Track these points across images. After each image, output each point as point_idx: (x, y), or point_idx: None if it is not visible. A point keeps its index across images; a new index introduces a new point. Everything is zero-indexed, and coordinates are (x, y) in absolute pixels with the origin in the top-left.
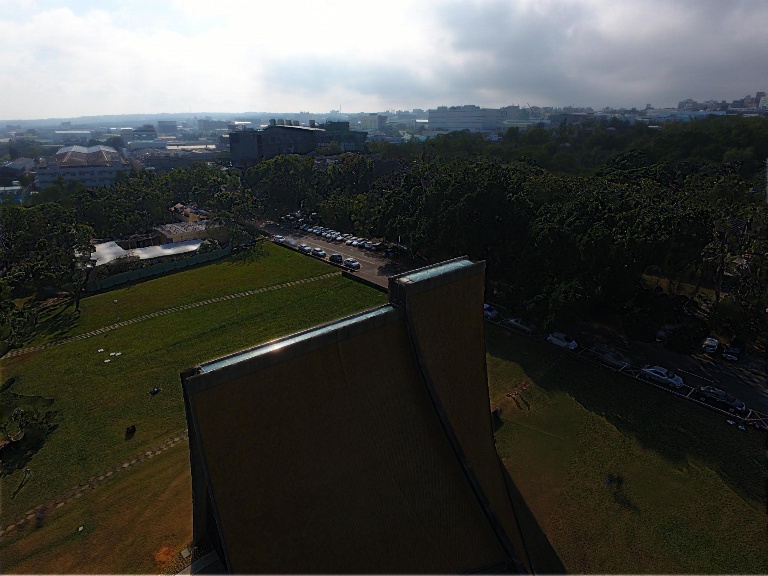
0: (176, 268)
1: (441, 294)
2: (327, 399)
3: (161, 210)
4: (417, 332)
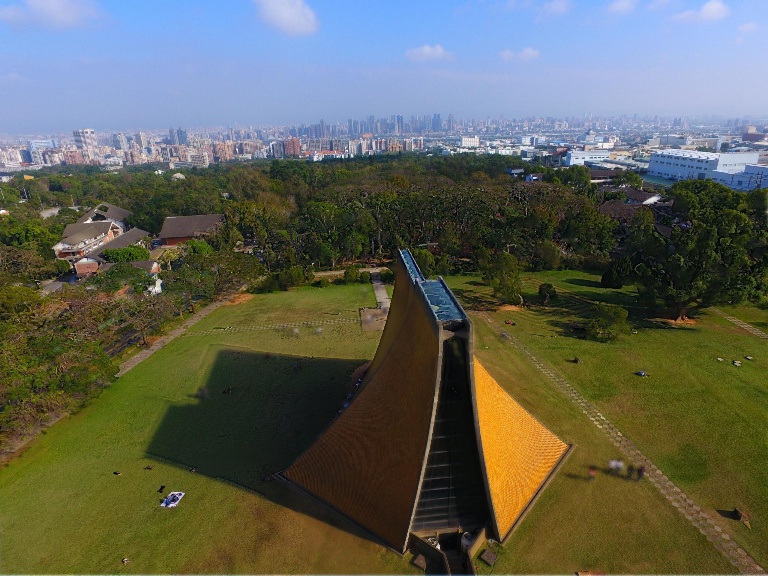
0: None
1: None
2: None
3: None
4: None
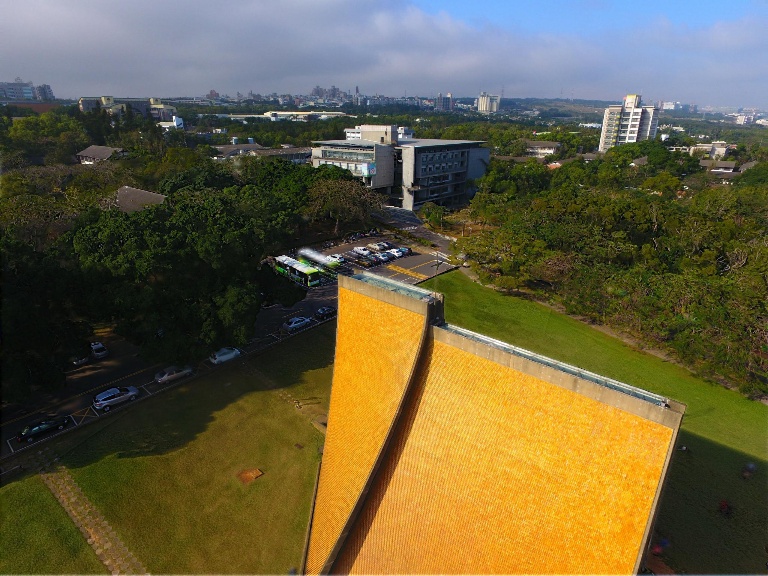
0: None
1: None
2: None
3: None
4: None
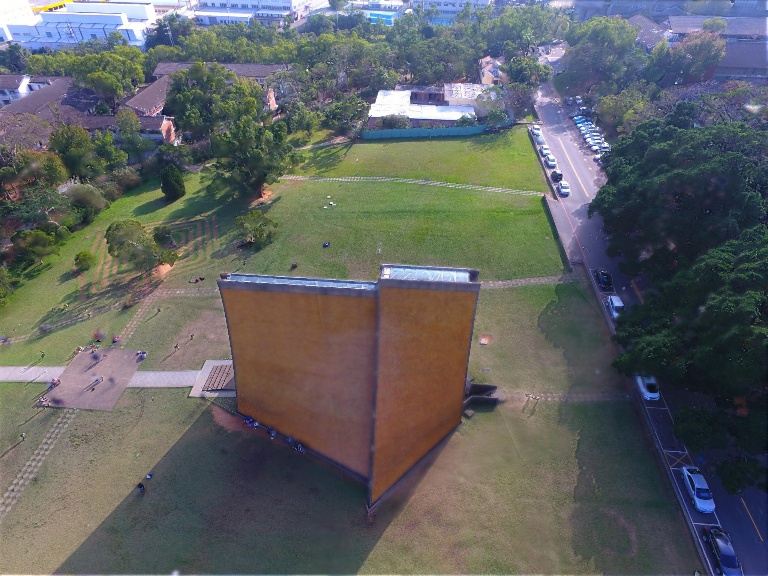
0: (429, 135)
1: (417, 294)
2: (304, 323)
3: (463, 64)
4: (381, 313)
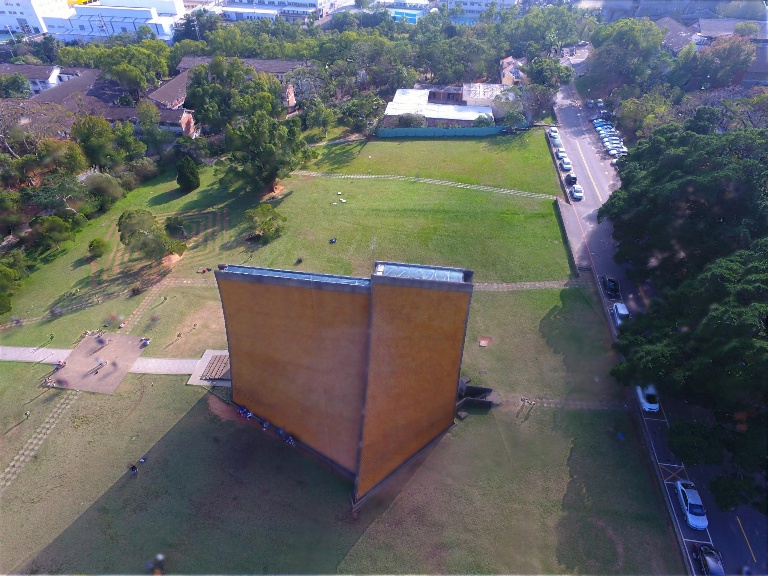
0: (445, 135)
1: (410, 292)
2: (298, 317)
3: (484, 64)
4: (374, 310)
